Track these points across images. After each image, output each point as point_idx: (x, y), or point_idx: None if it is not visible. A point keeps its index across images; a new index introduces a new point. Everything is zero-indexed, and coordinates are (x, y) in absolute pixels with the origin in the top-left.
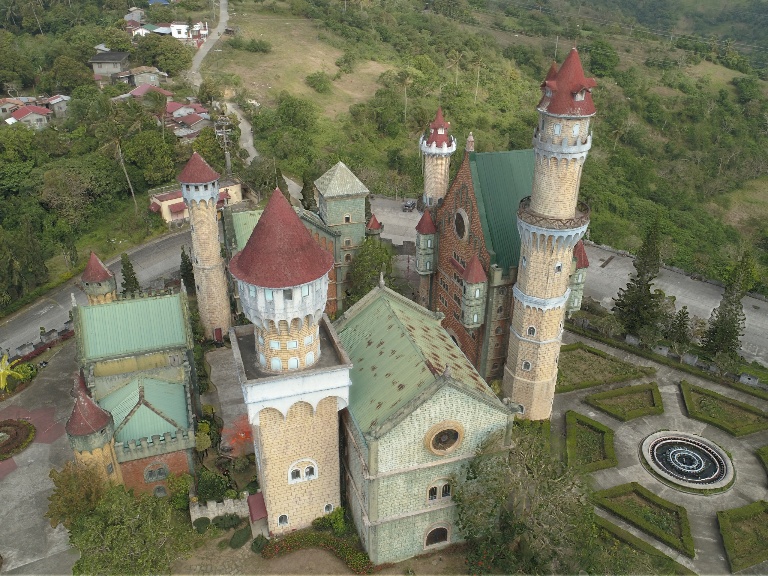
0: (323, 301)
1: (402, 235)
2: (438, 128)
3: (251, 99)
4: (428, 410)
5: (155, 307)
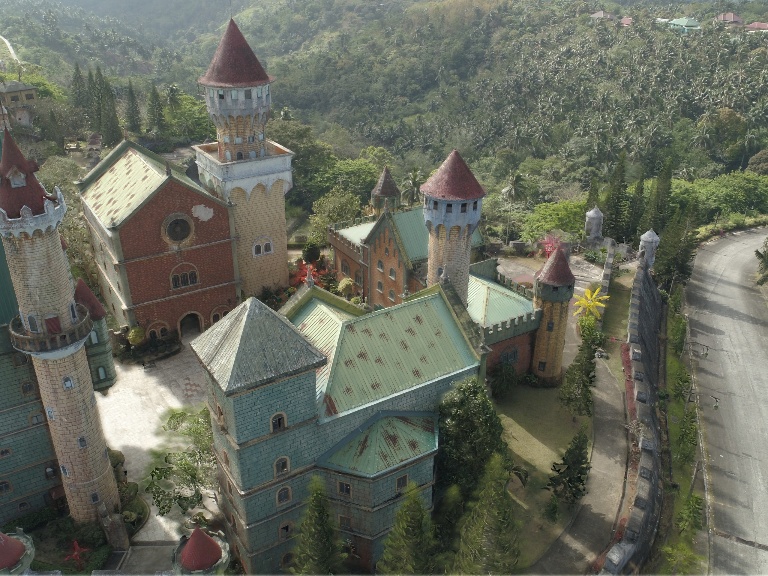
0: None
1: None
2: None
3: None
4: None
5: None
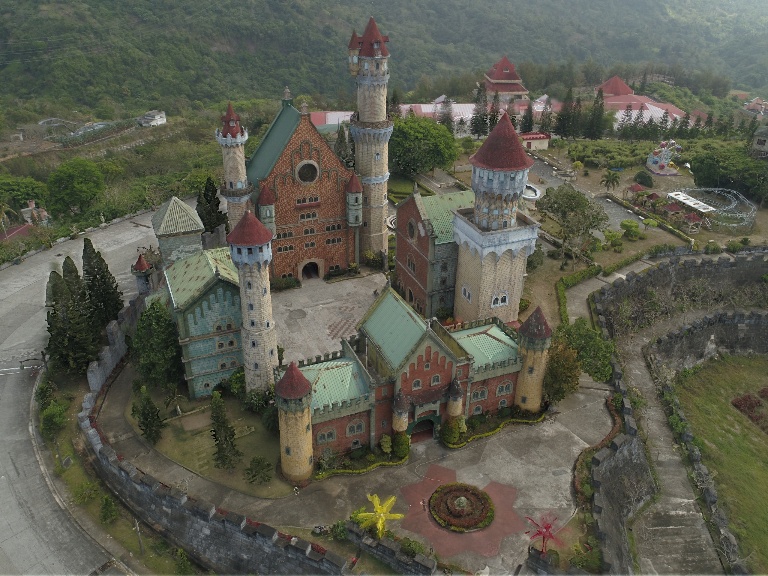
0: None
1: (42, 307)
2: None
3: None
4: None
5: None
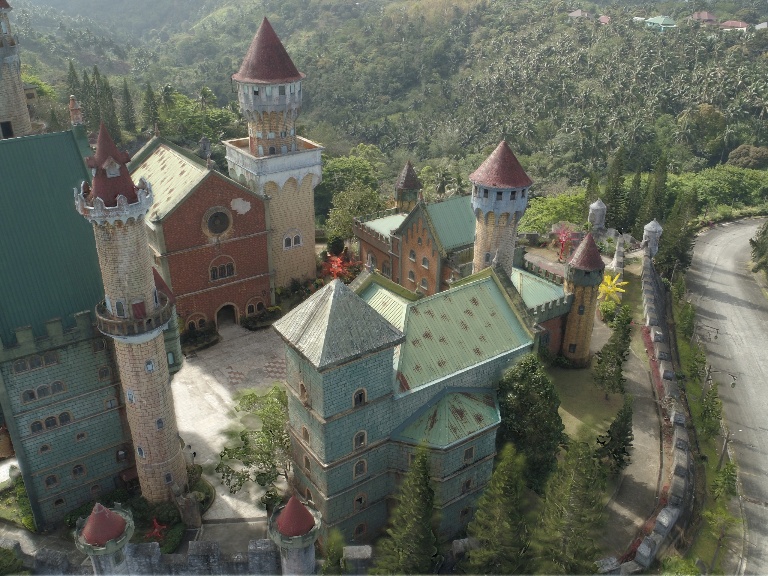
0: None
1: None
2: None
3: None
4: None
5: None
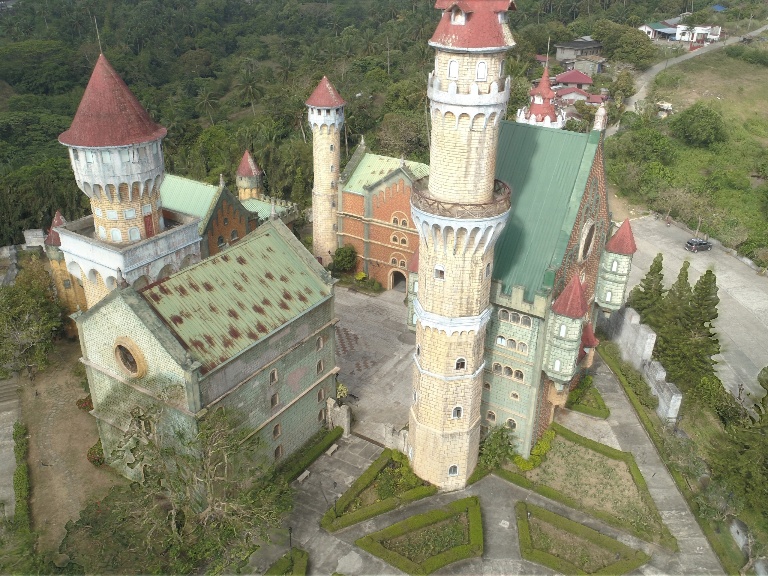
0: (121, 179)
1: (642, 268)
2: (534, 95)
3: (666, 101)
4: (112, 314)
5: (200, 191)
